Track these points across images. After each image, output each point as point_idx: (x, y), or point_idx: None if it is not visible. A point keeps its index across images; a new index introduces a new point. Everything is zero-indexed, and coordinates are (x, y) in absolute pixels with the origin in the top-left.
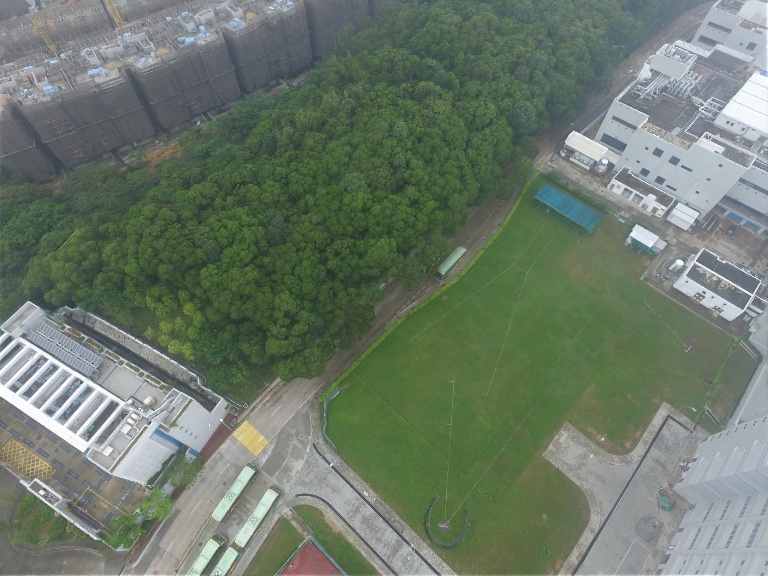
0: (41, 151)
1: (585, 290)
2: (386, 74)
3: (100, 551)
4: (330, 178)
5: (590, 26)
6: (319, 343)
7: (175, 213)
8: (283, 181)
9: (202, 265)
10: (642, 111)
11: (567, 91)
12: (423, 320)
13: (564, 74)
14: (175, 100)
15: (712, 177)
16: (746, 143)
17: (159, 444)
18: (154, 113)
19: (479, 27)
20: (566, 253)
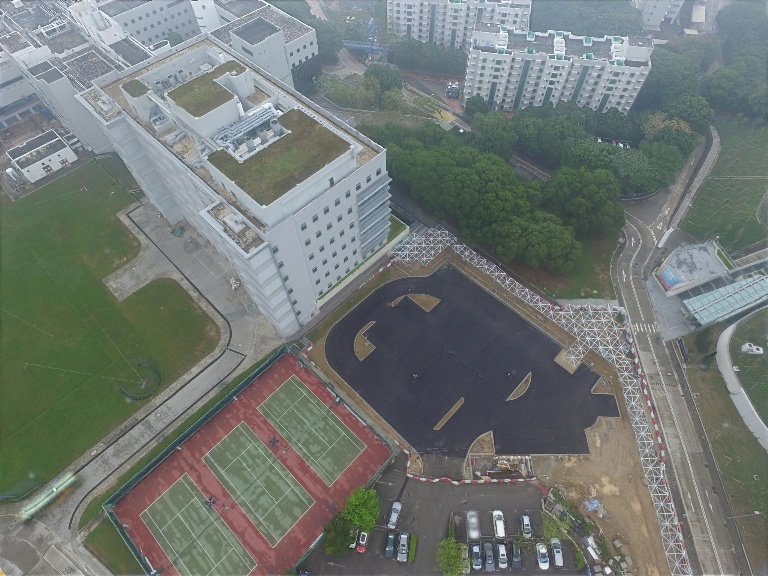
0: None
1: None
2: None
3: None
4: None
5: None
6: None
7: None
8: None
9: None
10: None
11: None
12: None
13: None
14: None
15: None
16: None
17: None
18: None
19: None
20: None
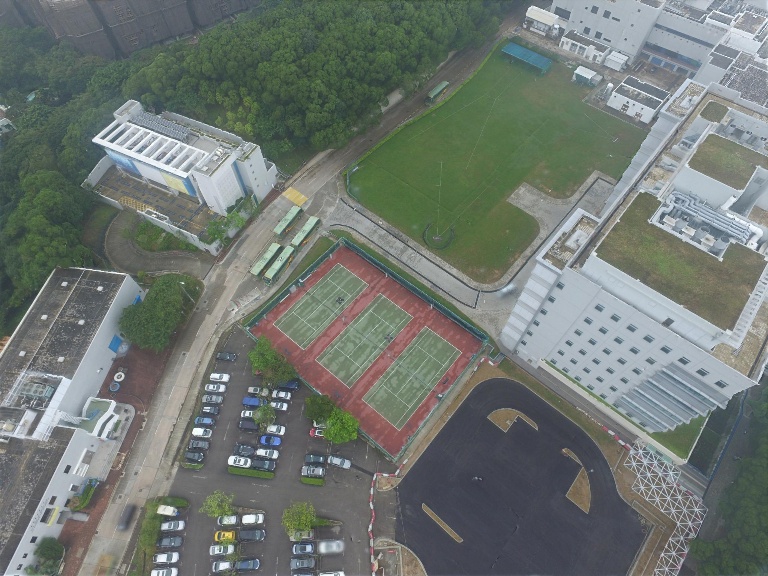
0: (107, 36)
1: (540, 108)
2: None
3: (196, 256)
4: (345, 15)
5: None
6: (343, 121)
7: (235, 33)
8: (311, 16)
9: (257, 65)
10: None
11: None
12: (418, 128)
13: None
14: None
15: (634, 22)
16: None
17: (235, 178)
18: (193, 11)
19: None
20: (526, 87)
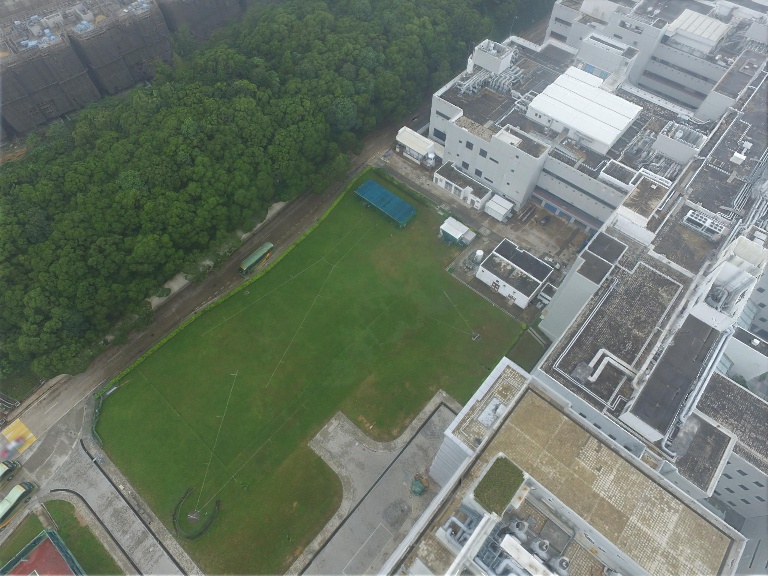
0: None
1: (388, 282)
2: (210, 73)
3: None
4: (110, 176)
5: (428, 23)
6: (79, 339)
7: None
8: (60, 180)
9: None
10: (460, 105)
11: (393, 87)
12: (220, 315)
13: (393, 71)
14: (23, 103)
15: (514, 168)
16: (553, 135)
17: None
18: (3, 117)
19: (310, 26)
20: (378, 246)
